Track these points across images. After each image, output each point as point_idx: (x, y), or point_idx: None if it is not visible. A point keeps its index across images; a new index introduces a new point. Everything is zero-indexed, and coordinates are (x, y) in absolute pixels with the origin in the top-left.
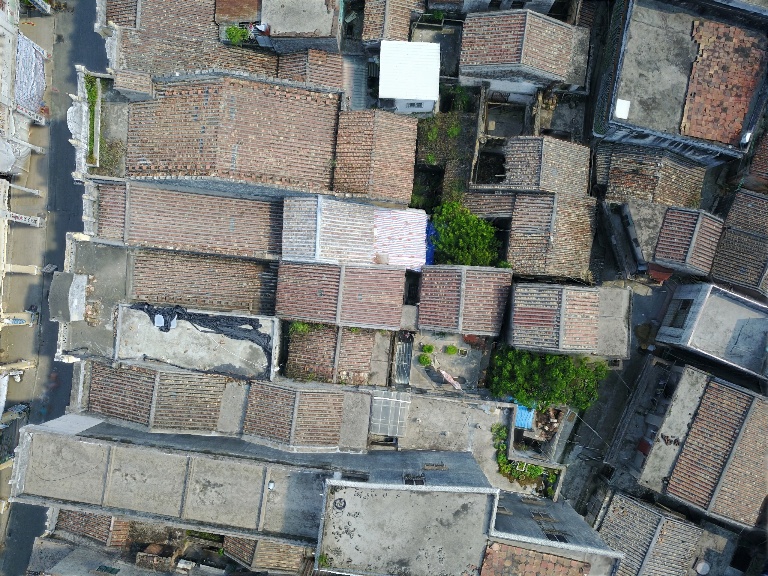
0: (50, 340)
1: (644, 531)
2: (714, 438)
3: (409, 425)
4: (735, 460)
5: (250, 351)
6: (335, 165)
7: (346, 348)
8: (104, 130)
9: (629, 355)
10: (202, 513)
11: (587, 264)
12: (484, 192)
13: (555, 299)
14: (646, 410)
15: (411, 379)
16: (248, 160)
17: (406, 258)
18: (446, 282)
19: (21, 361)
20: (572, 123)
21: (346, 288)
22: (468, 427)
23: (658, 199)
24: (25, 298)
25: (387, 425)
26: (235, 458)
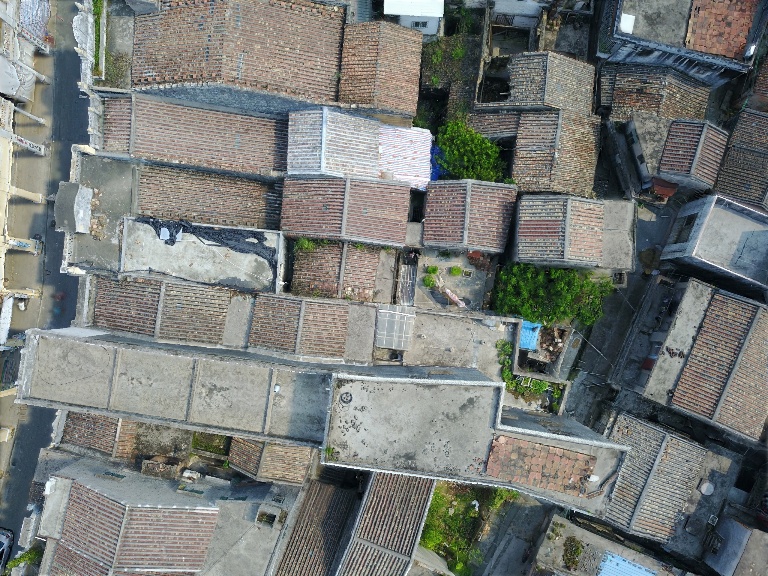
0: (54, 270)
1: (648, 449)
2: (719, 349)
3: (414, 341)
4: (740, 370)
5: (255, 264)
6: (340, 78)
7: (351, 264)
8: (110, 44)
9: (634, 268)
10: (208, 417)
11: (592, 182)
12: (489, 112)
13: (560, 210)
14: (650, 329)
15: (416, 300)
16: (254, 69)
17: (411, 177)
18: (451, 197)
19: (25, 289)
20: (576, 44)
21: (351, 201)
22: (473, 343)
23: (662, 117)
24: (29, 227)
25: (392, 339)
26: (241, 359)
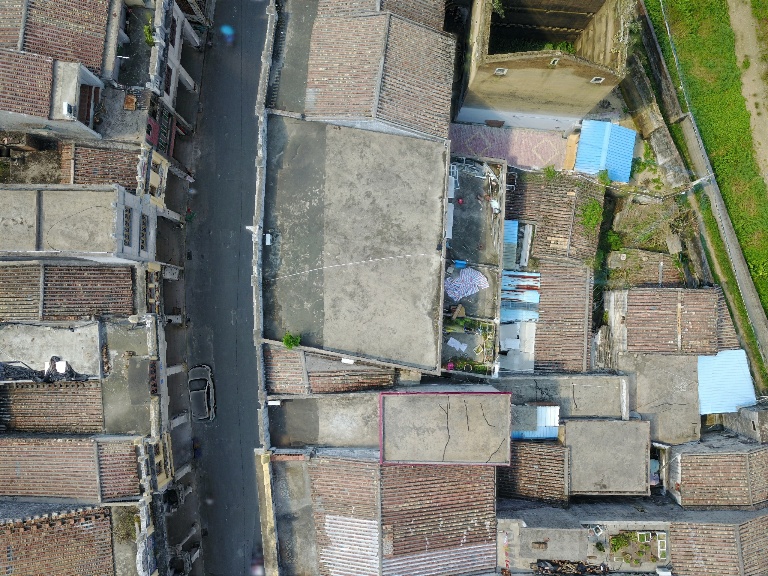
0: None
1: None
2: None
3: None
4: None
5: None
6: None
7: None
8: None
9: None
10: None
11: None
12: None
13: None
14: None
15: None
16: None
17: None
18: None
19: None
20: None
21: None
22: None
23: None
24: None
25: None
26: None
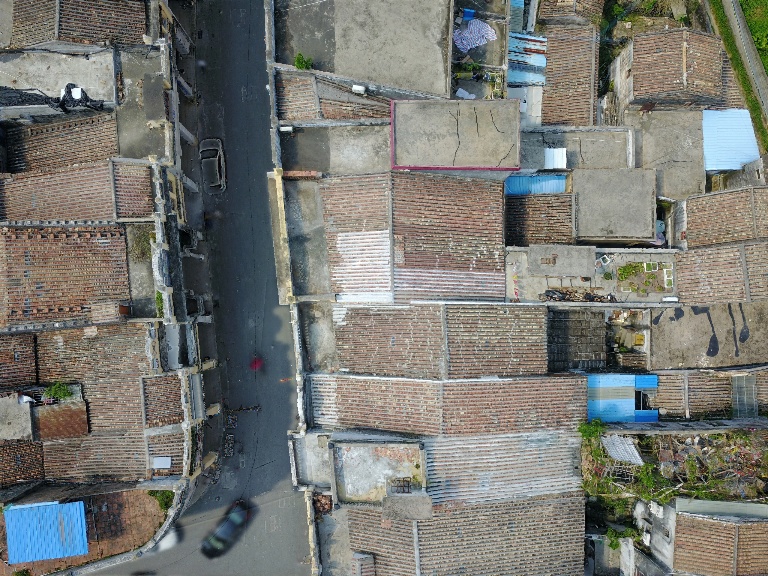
0: None
1: None
2: None
3: None
4: None
5: None
6: None
7: None
8: None
9: None
10: None
11: None
12: None
13: None
14: None
15: None
16: None
17: None
18: None
19: None
20: None
21: None
22: None
23: None
24: None
25: None
26: None
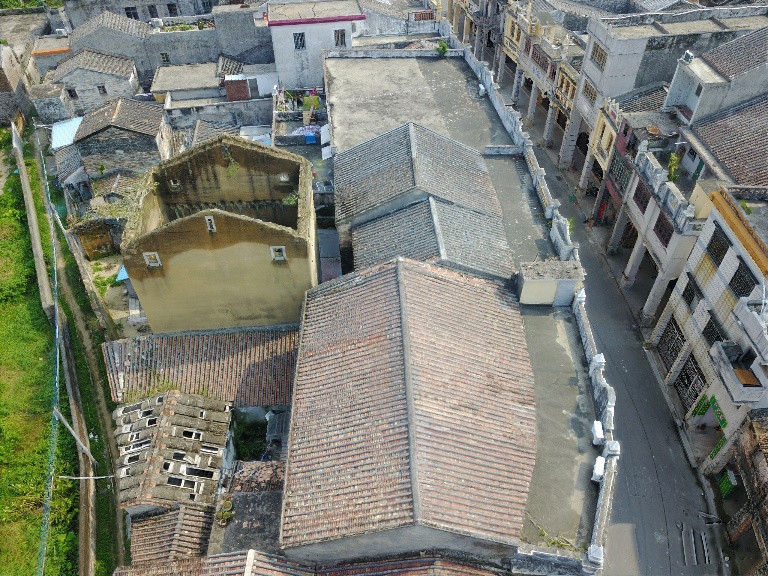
0: None
1: None
2: None
3: None
4: None
5: None
6: None
7: None
8: None
9: None
10: None
11: None
12: None
13: None
14: None
15: None
16: None
17: None
18: None
19: None
20: None
21: None
22: None
23: None
24: None
25: None
26: None
